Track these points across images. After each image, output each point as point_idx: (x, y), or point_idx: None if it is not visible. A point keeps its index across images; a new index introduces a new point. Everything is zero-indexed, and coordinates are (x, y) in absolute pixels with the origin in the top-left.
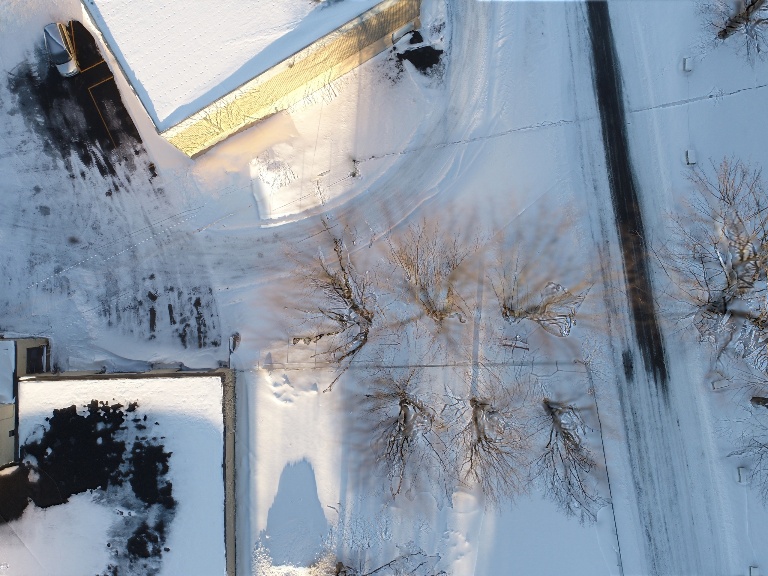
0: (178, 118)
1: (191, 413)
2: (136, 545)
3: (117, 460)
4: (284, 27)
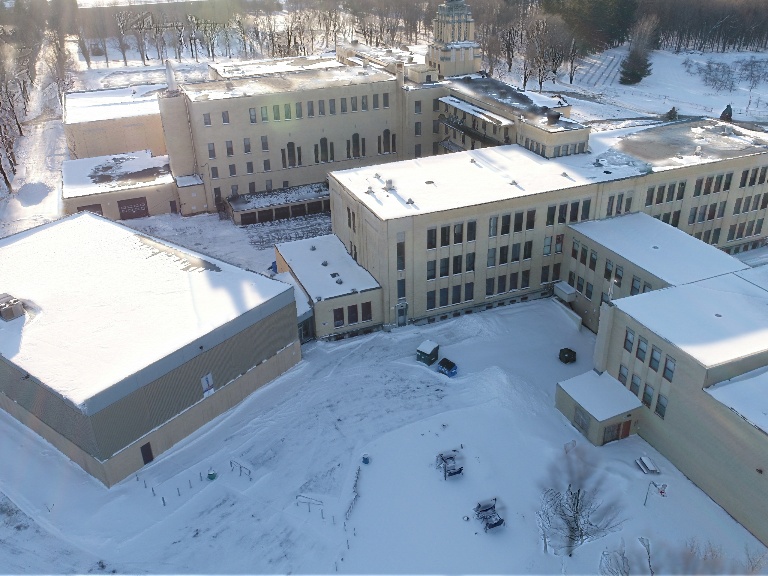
0: (75, 216)
1: (81, 190)
2: (108, 168)
3: (120, 178)
4: (3, 249)
